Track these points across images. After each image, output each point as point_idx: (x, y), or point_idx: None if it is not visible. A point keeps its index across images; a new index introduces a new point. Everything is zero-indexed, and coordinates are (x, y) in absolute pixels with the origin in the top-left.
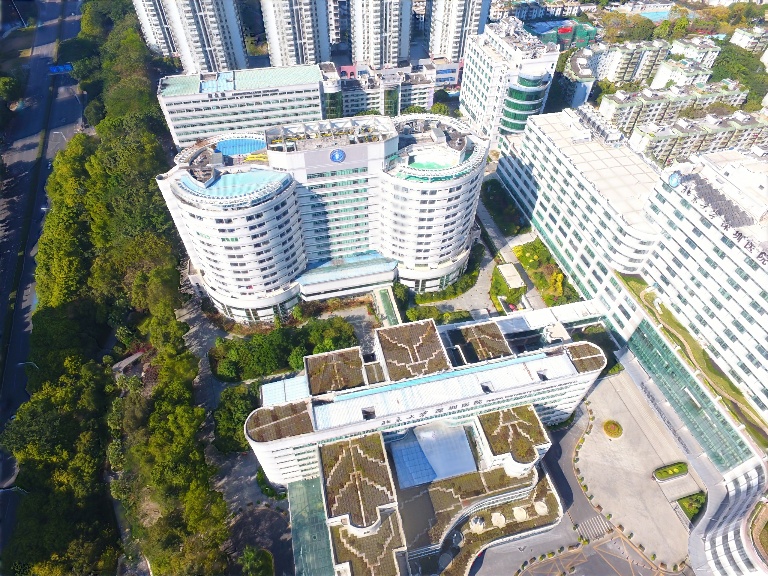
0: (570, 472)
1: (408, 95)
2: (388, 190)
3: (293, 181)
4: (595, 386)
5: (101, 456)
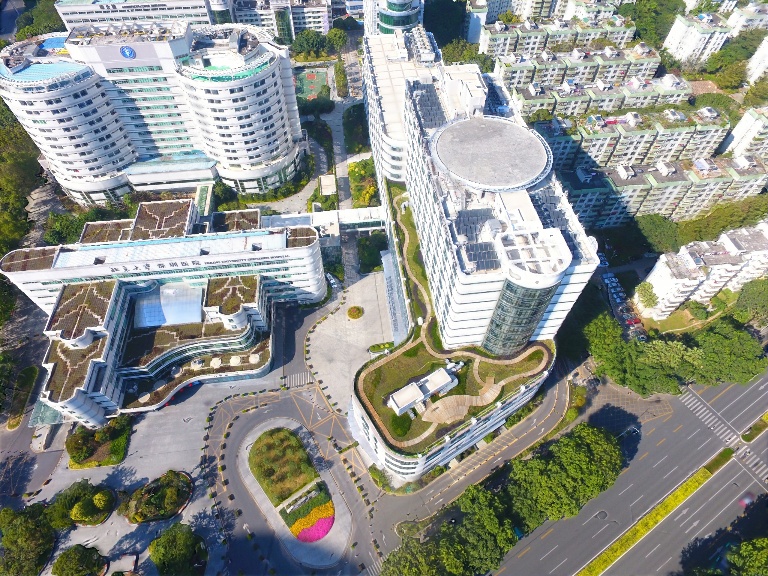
0: (301, 339)
1: (302, 18)
2: (184, 89)
3: (94, 74)
4: (360, 279)
5: None
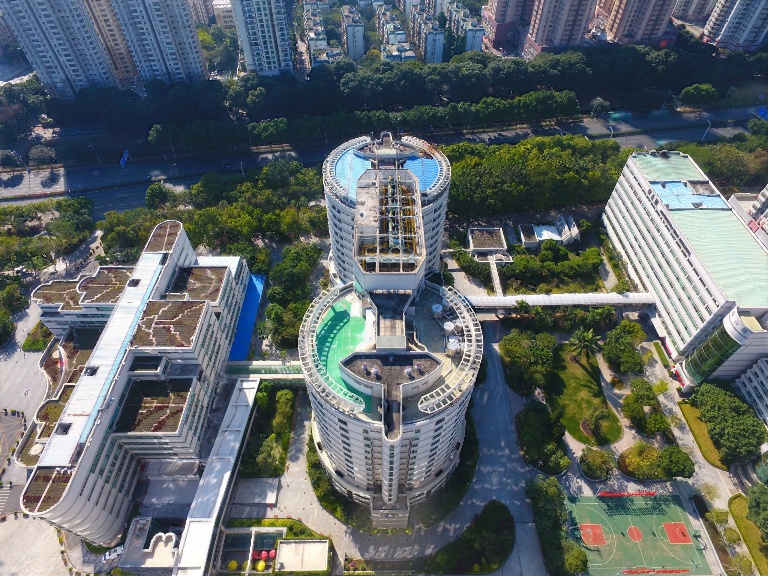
0: None
1: None
2: None
3: None
4: None
5: None
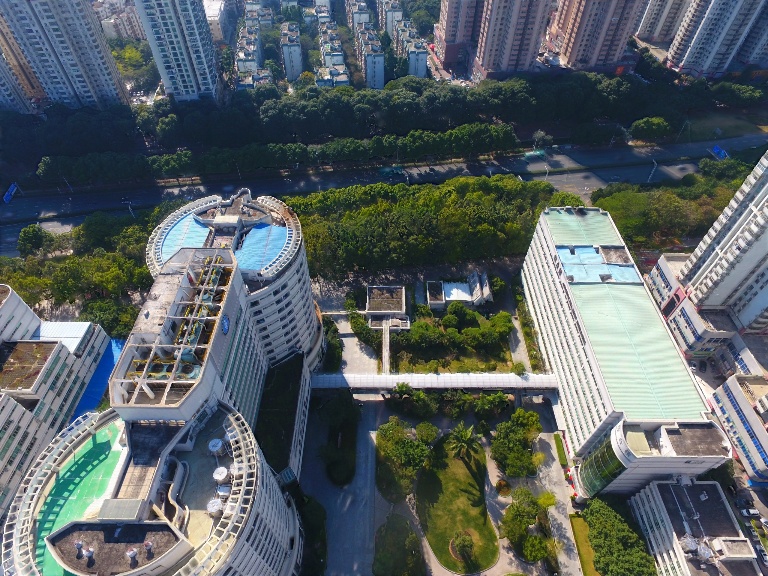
0: None
1: None
2: None
3: None
4: None
5: None
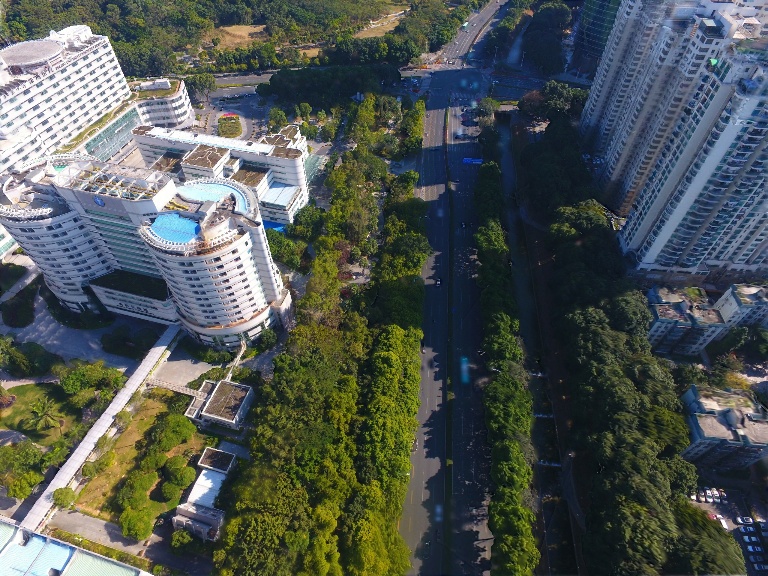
0: None
1: None
2: None
3: None
4: None
5: (383, 230)
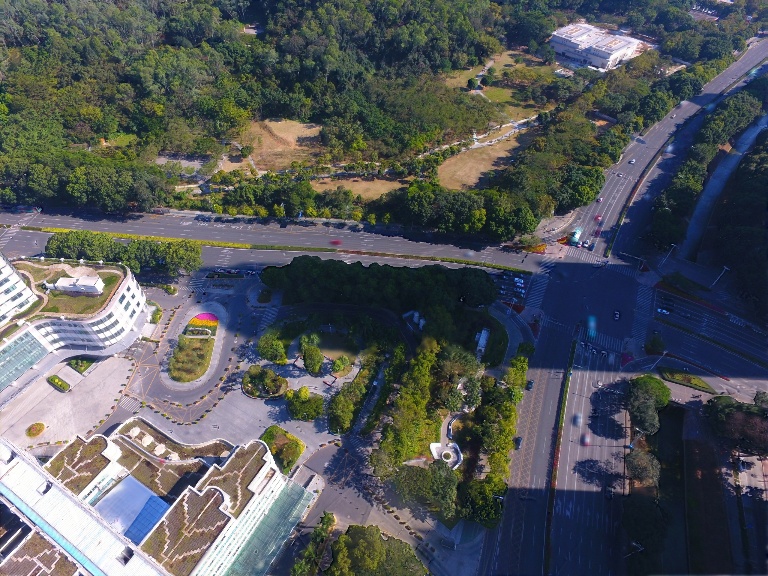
0: None
1: None
2: None
3: None
4: None
5: None
